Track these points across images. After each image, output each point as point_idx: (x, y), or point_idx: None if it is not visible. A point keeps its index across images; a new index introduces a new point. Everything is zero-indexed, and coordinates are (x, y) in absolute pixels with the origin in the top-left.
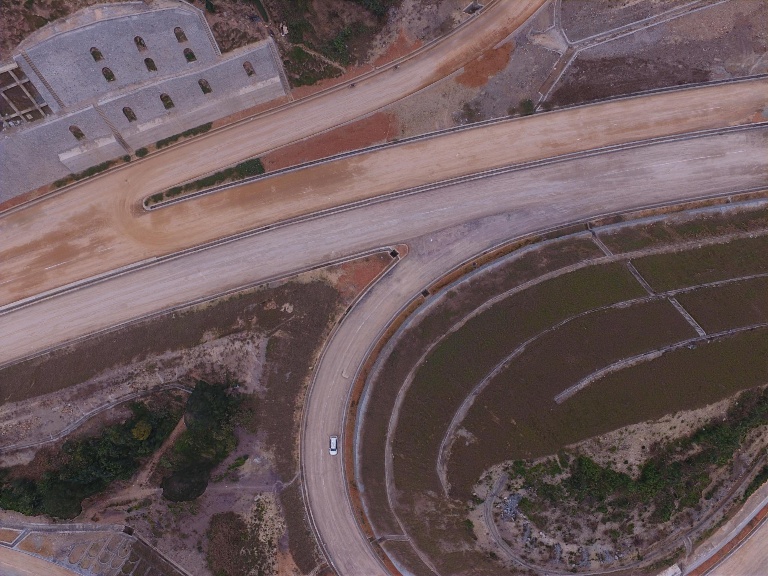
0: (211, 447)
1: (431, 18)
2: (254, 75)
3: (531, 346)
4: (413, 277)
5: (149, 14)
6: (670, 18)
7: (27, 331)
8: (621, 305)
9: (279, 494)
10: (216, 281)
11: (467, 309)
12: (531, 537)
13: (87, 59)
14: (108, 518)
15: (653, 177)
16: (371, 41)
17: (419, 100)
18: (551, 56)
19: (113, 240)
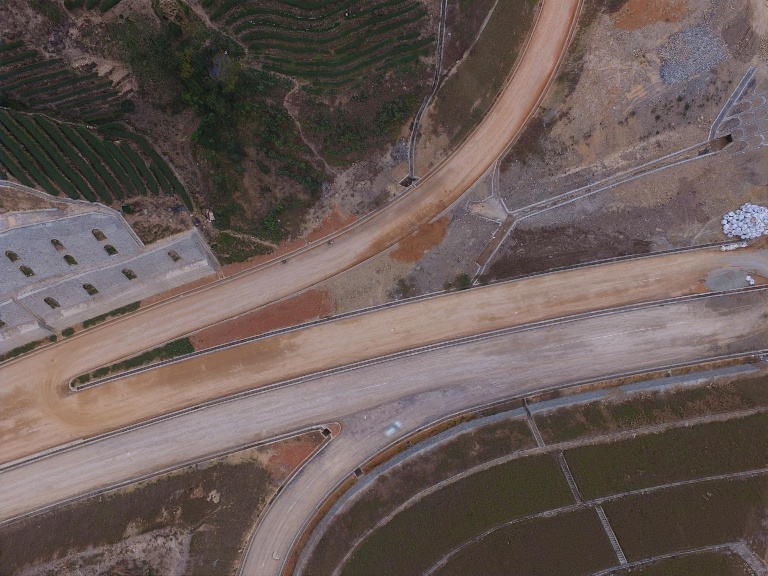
0: None
1: (365, 194)
2: (181, 260)
3: (454, 558)
4: (346, 455)
5: (64, 220)
6: (612, 185)
7: None
8: (547, 514)
9: None
10: (144, 462)
11: (396, 502)
12: None
13: (3, 261)
14: None
15: (592, 350)
16: (304, 215)
17: (352, 277)
18: (489, 227)
19: (39, 421)
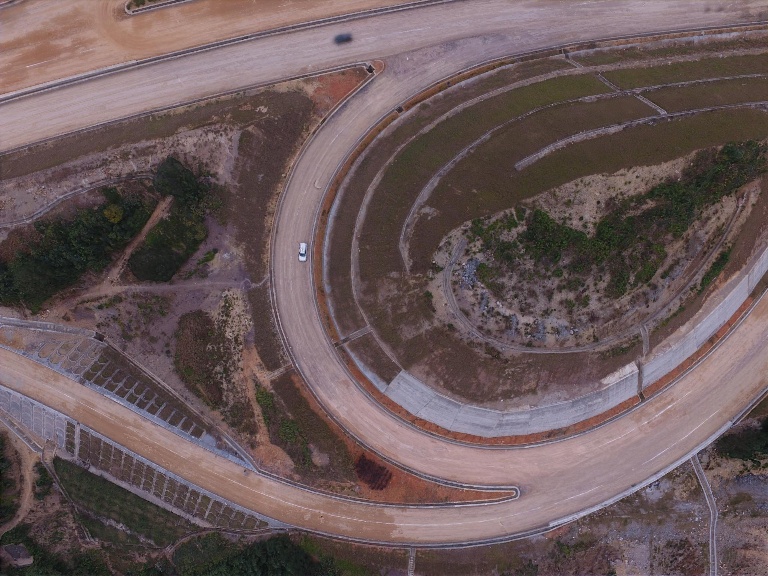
0: (181, 240)
1: None
2: None
3: (497, 133)
4: (388, 94)
5: None
6: None
7: (6, 127)
8: (587, 99)
9: (247, 292)
10: (194, 88)
11: (438, 113)
12: (488, 306)
13: None
14: (79, 321)
15: (628, 9)
16: None
17: None
18: None
19: (94, 42)
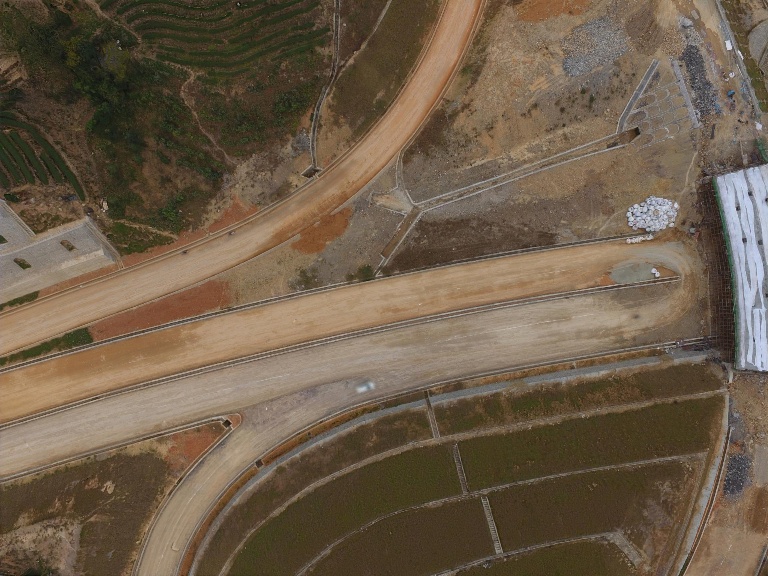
0: None
1: (265, 185)
2: (76, 249)
3: (338, 548)
4: (247, 447)
5: None
6: (519, 177)
7: None
8: (432, 504)
9: None
10: (43, 452)
11: (289, 492)
12: None
13: None
14: None
15: (497, 342)
16: (206, 205)
17: (253, 267)
18: (393, 219)
19: None
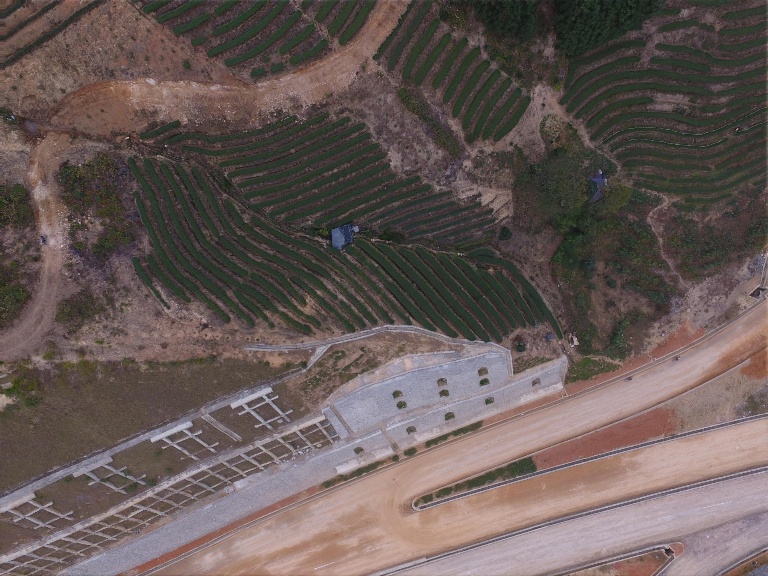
0: None
1: (719, 309)
2: (538, 384)
3: None
4: (687, 575)
5: (460, 362)
6: None
7: None
8: None
9: None
10: None
11: None
12: None
13: (387, 399)
14: None
15: None
16: (648, 329)
17: (701, 394)
18: None
19: (381, 540)
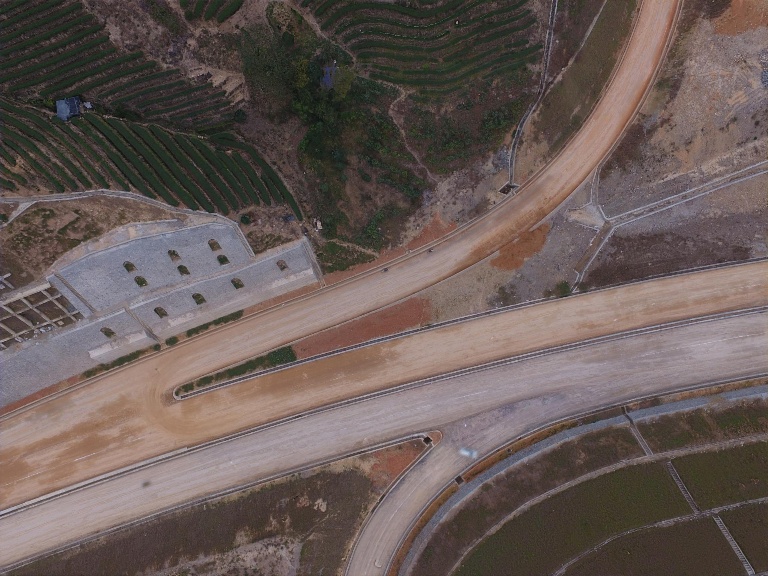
0: None
1: (466, 202)
2: (287, 269)
3: (573, 568)
4: (447, 463)
5: (184, 231)
6: (709, 191)
7: (57, 522)
8: (664, 524)
9: None
10: (247, 470)
11: (504, 510)
12: None
13: (120, 271)
14: None
15: (691, 357)
16: (404, 223)
17: (454, 285)
18: (588, 234)
19: (143, 430)
